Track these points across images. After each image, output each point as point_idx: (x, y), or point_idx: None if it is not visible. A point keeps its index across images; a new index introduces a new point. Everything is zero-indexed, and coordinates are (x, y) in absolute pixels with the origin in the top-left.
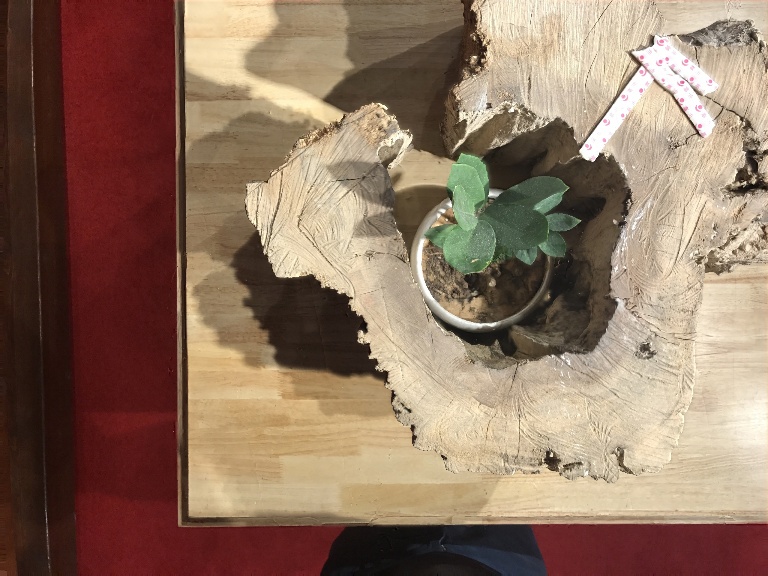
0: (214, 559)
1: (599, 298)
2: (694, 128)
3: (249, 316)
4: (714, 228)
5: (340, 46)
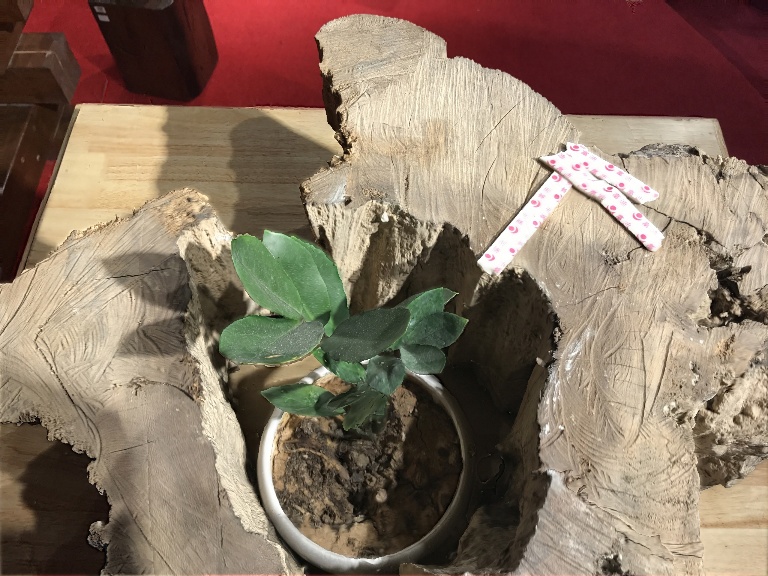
0: None
1: (528, 486)
2: (636, 240)
3: (23, 560)
4: (693, 370)
5: (224, 221)
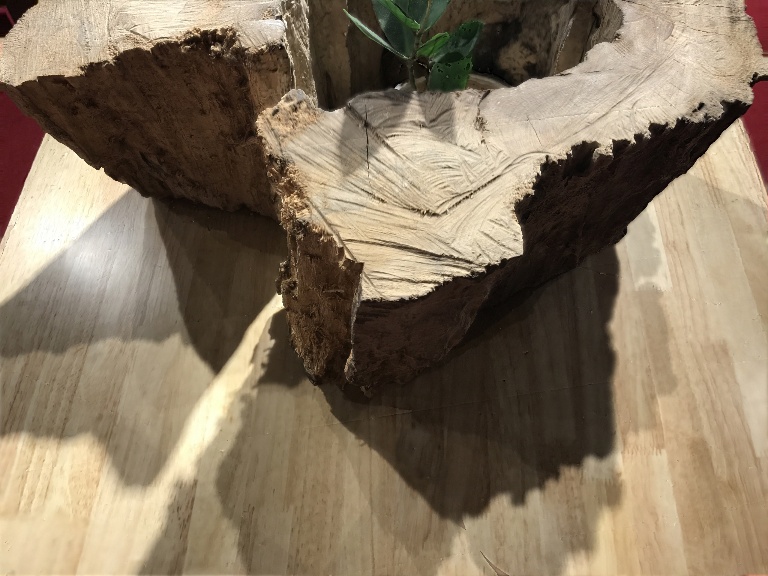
0: None
1: None
2: None
3: (540, 497)
4: None
5: (145, 350)
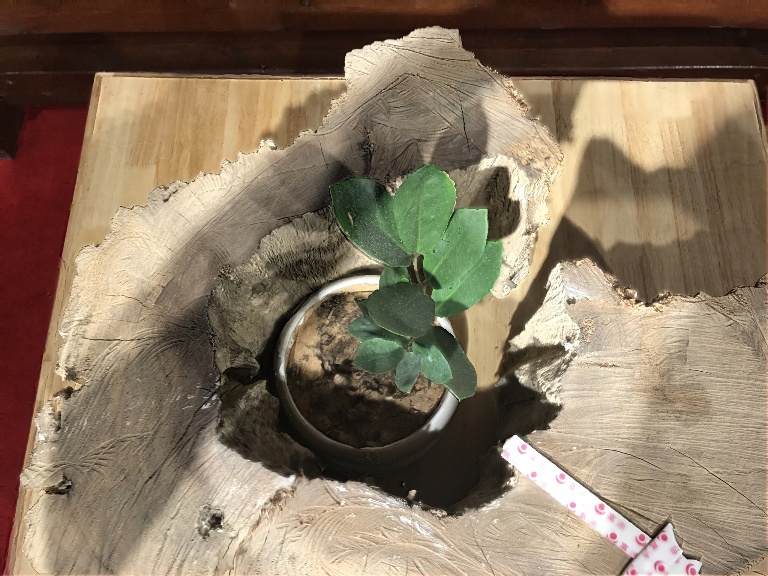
0: (56, 109)
1: None
2: None
3: None
4: None
5: (629, 235)
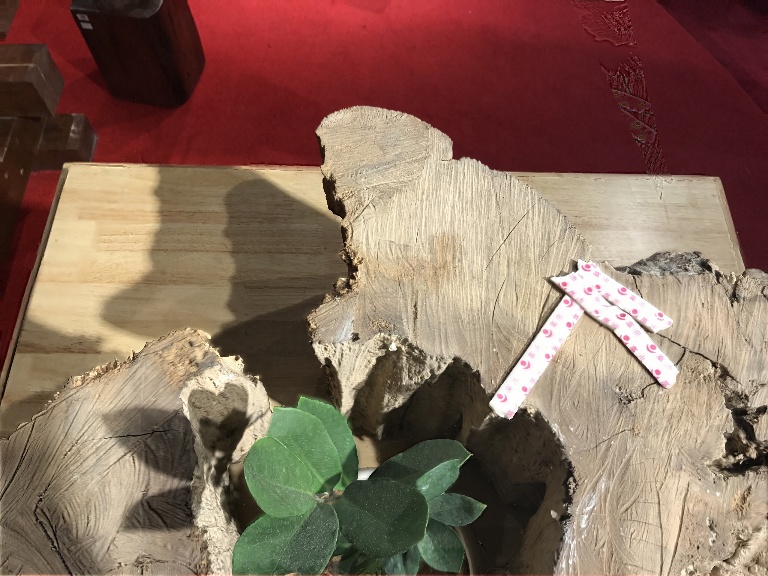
0: None
1: None
2: (650, 375)
3: None
4: (710, 527)
5: (221, 295)
